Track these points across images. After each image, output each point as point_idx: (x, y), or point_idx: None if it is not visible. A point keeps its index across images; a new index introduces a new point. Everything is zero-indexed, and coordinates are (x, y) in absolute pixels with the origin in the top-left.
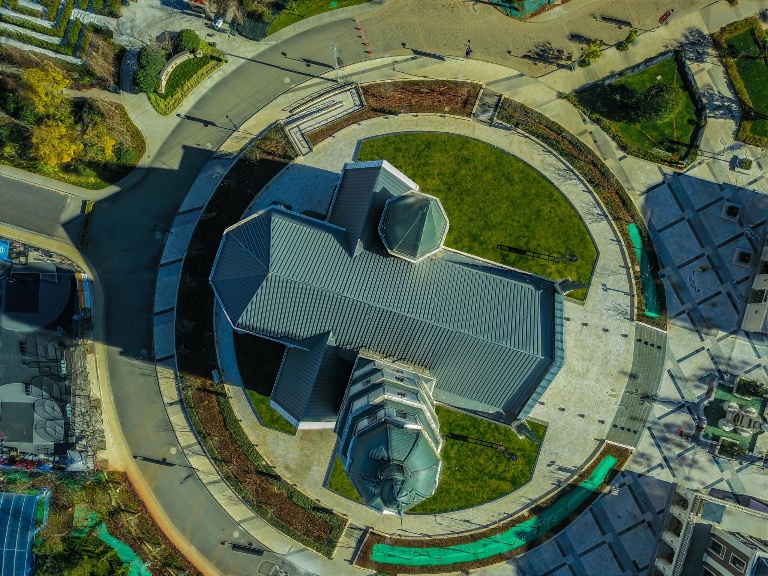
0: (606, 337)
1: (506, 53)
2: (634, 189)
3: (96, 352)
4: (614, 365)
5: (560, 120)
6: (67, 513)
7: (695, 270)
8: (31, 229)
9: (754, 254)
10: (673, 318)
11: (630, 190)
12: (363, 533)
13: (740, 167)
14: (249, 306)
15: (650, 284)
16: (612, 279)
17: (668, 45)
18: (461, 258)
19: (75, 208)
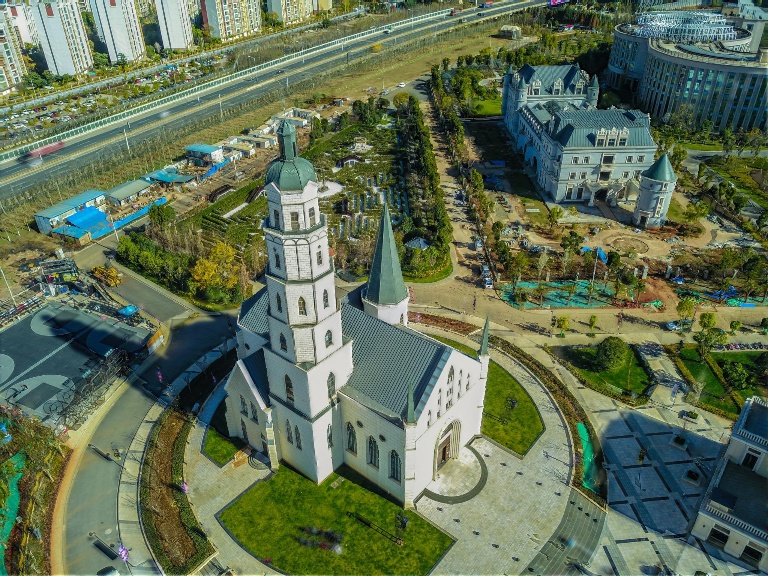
0: (539, 490)
1: (504, 320)
2: (588, 407)
3: (129, 377)
4: (542, 514)
5: (534, 357)
6: (6, 456)
7: (641, 473)
8: (154, 316)
9: (704, 478)
10: (614, 503)
11: (584, 407)
12: (220, 573)
13: (687, 416)
14: (257, 304)
15: (592, 467)
16: (554, 450)
17: (627, 342)
18: (412, 332)
19: (187, 315)
